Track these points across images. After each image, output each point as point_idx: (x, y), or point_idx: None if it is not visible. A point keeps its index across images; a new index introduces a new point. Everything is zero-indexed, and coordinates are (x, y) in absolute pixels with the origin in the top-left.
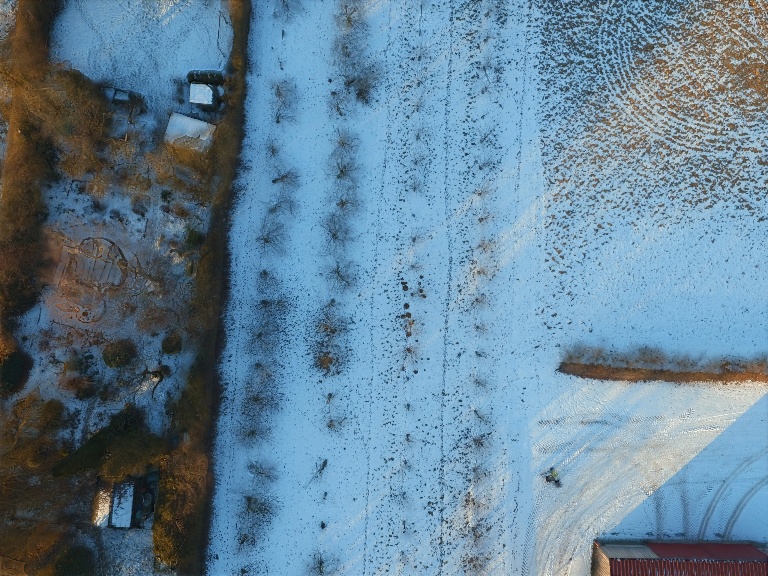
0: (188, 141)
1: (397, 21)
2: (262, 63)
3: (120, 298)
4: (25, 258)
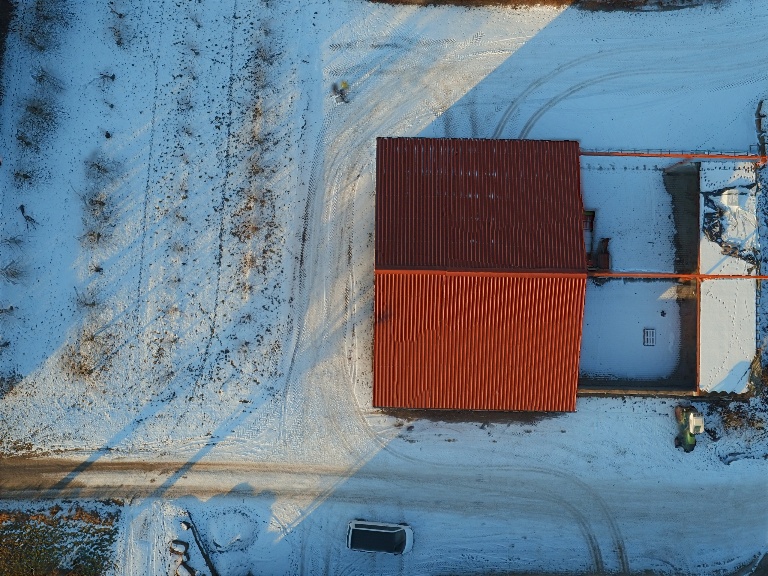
0: None
1: None
2: None
3: None
4: None
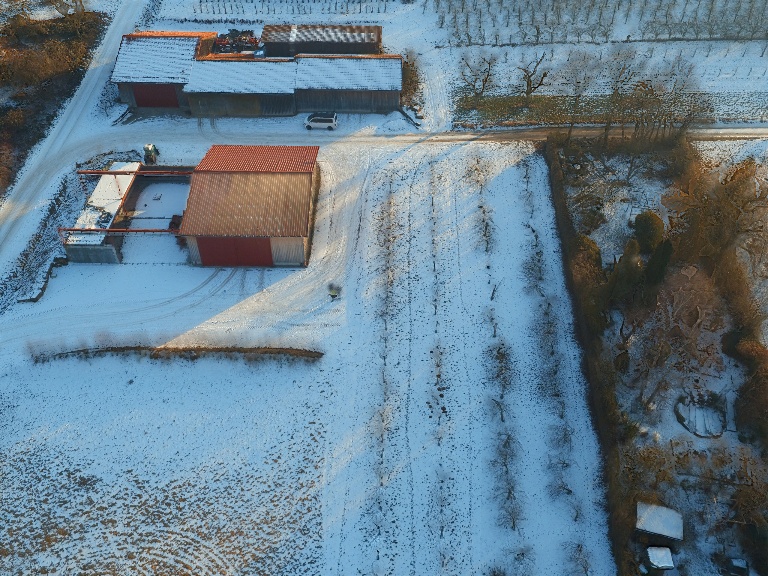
0: (653, 461)
1: None
2: None
3: (674, 395)
4: (760, 406)
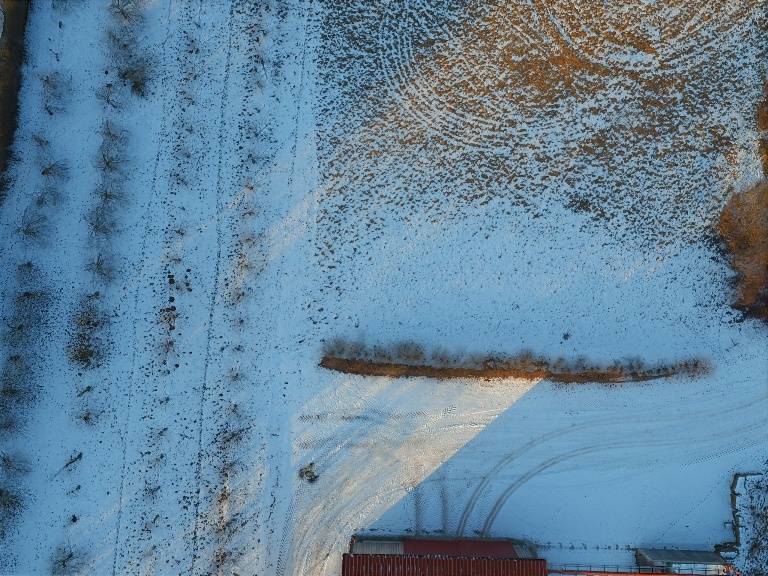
0: None
1: (177, 14)
2: (38, 54)
3: None
4: None
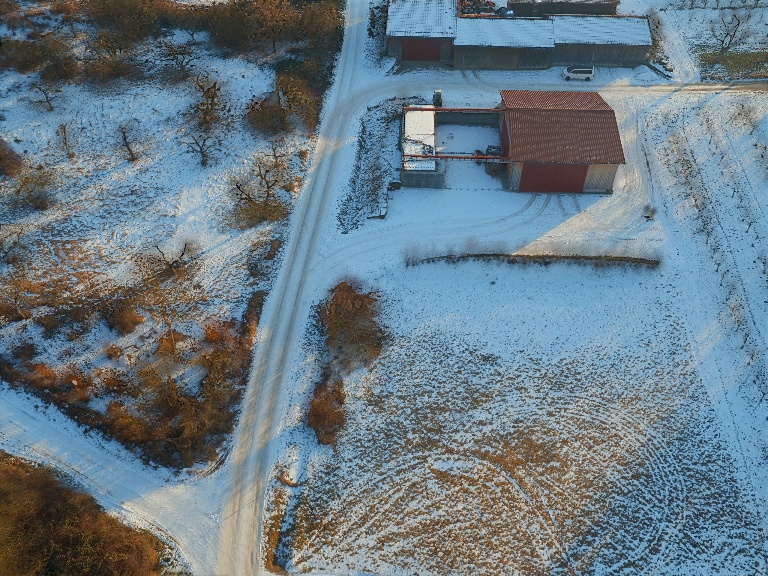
0: None
1: None
2: None
3: None
4: None
